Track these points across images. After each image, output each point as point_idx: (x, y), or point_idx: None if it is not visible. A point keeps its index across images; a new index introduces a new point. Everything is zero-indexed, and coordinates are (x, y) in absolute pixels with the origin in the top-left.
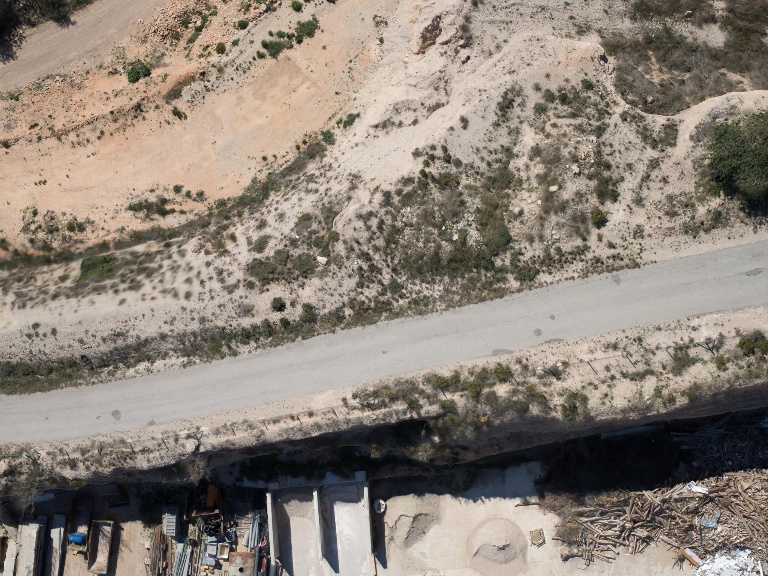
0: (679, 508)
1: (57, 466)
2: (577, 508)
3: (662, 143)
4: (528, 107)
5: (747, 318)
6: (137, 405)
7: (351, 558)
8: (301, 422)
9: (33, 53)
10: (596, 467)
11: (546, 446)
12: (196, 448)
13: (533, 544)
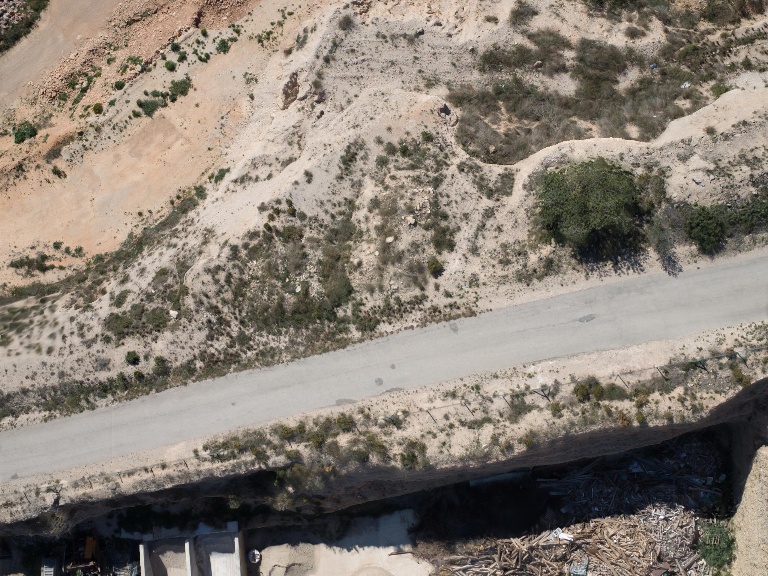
0: (548, 555)
1: None
2: (449, 556)
3: (499, 192)
4: (370, 160)
5: (582, 364)
6: (1, 459)
7: None
8: (154, 474)
9: None
10: (464, 515)
11: (417, 494)
12: (55, 501)
13: None
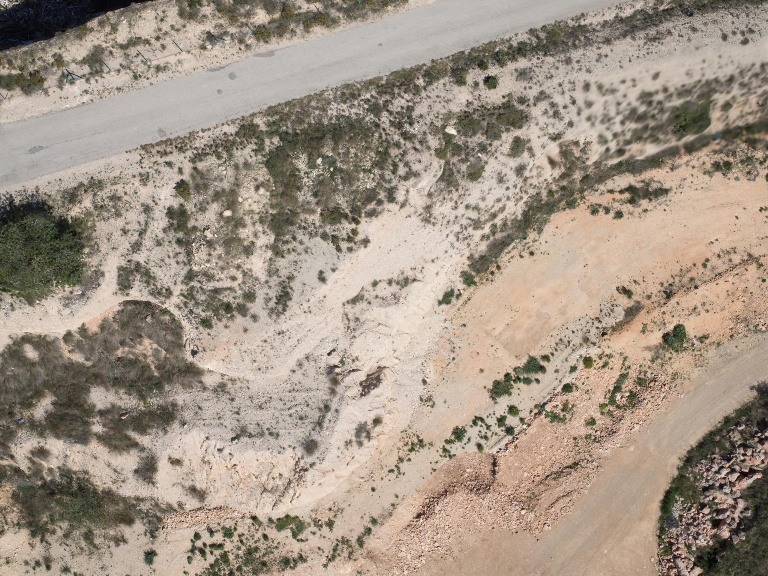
0: None
1: None
2: None
3: (131, 270)
4: (262, 298)
5: (39, 106)
6: None
7: None
8: None
9: None
10: None
11: None
12: None
13: None
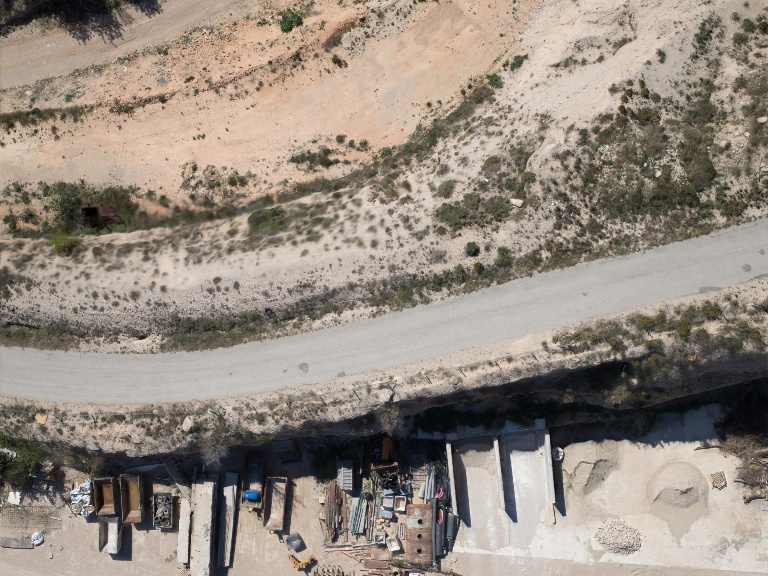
0: None
1: (244, 421)
2: (760, 449)
3: None
4: (727, 38)
5: None
6: (325, 357)
7: (529, 507)
8: (500, 368)
9: (178, 6)
10: None
11: (726, 388)
12: (390, 398)
13: (714, 487)
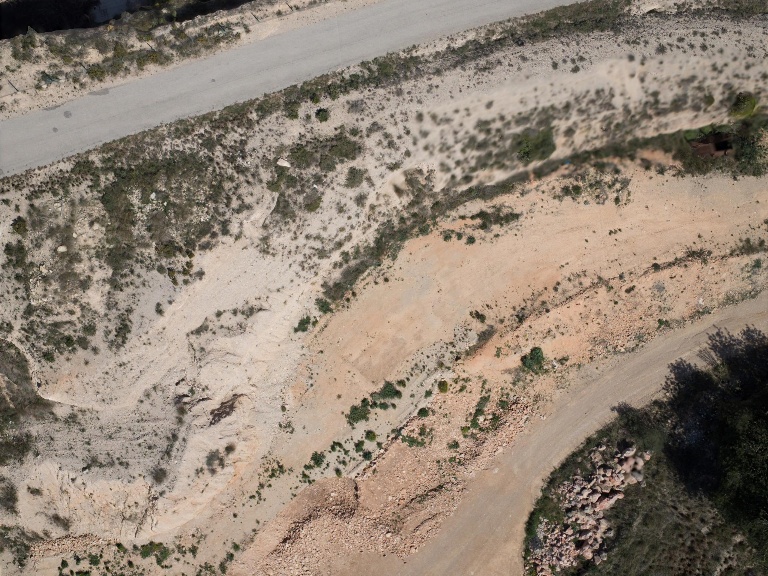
0: None
1: None
2: None
3: None
4: (102, 331)
5: None
6: (460, 4)
7: None
8: (287, 4)
9: (652, 373)
10: (39, 20)
11: None
12: None
13: None
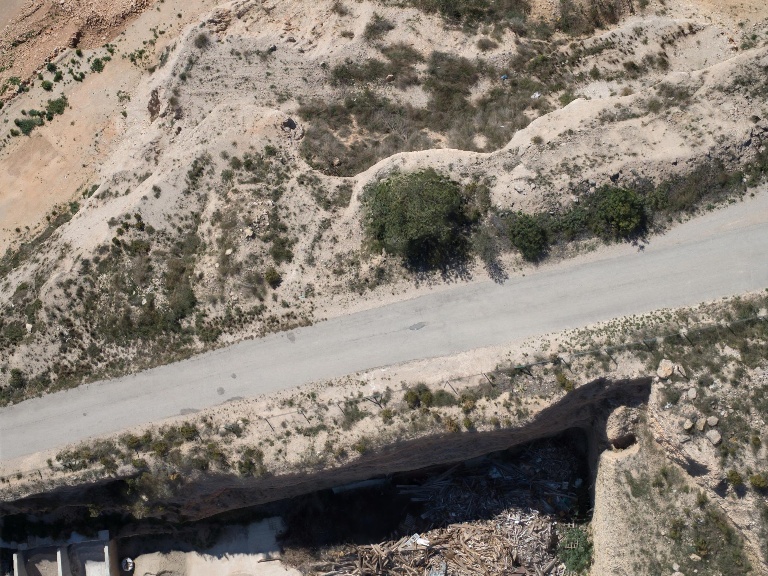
0: (407, 561)
1: None
2: (314, 563)
3: (336, 204)
4: (216, 174)
5: (412, 371)
6: None
7: None
8: (9, 484)
9: None
10: (326, 521)
11: (284, 501)
12: None
13: None
